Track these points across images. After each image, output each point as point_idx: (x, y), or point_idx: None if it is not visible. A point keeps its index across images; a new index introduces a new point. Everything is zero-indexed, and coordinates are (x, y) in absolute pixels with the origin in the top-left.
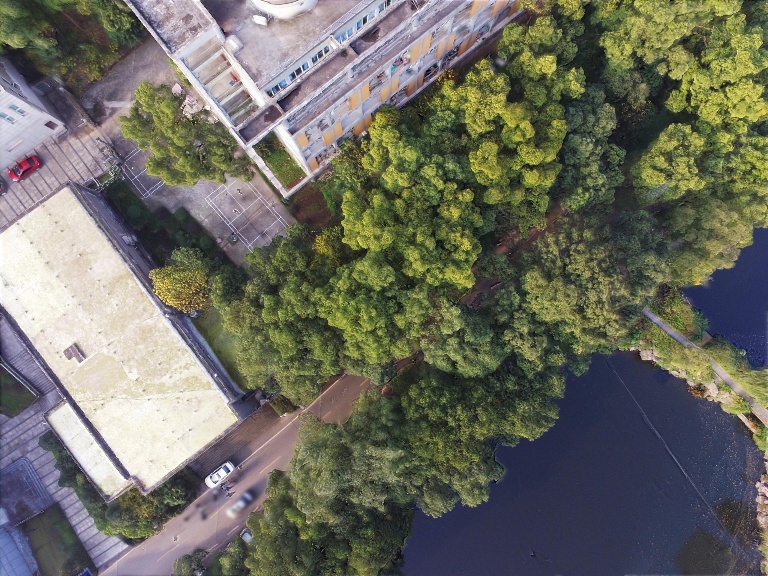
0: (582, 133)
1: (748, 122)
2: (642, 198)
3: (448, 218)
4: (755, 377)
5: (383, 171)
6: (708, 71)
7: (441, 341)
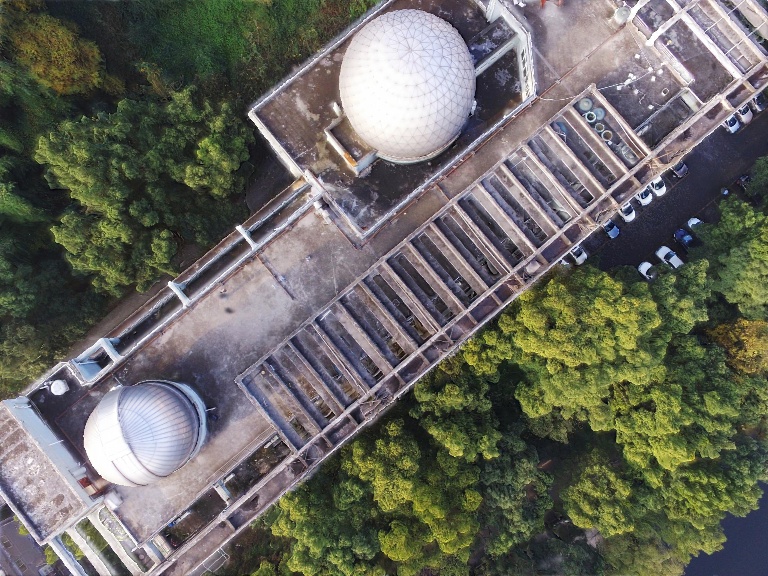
0: (501, 485)
1: None
2: None
3: None
4: None
5: (293, 540)
6: (629, 420)
7: None
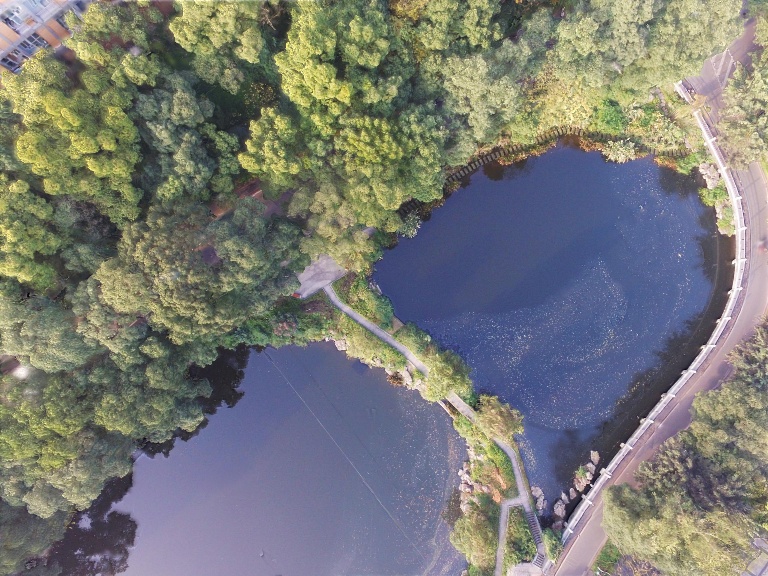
0: (161, 120)
1: (345, 104)
2: (271, 185)
3: None
4: (431, 363)
5: None
6: (284, 54)
7: None
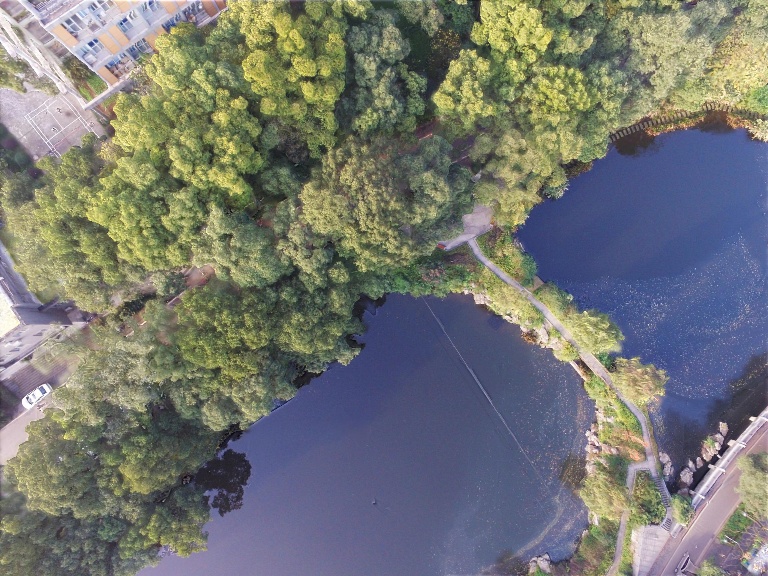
0: (368, 53)
1: (540, 52)
2: (449, 129)
3: (218, 123)
4: (576, 320)
5: None
6: None
7: (210, 246)
